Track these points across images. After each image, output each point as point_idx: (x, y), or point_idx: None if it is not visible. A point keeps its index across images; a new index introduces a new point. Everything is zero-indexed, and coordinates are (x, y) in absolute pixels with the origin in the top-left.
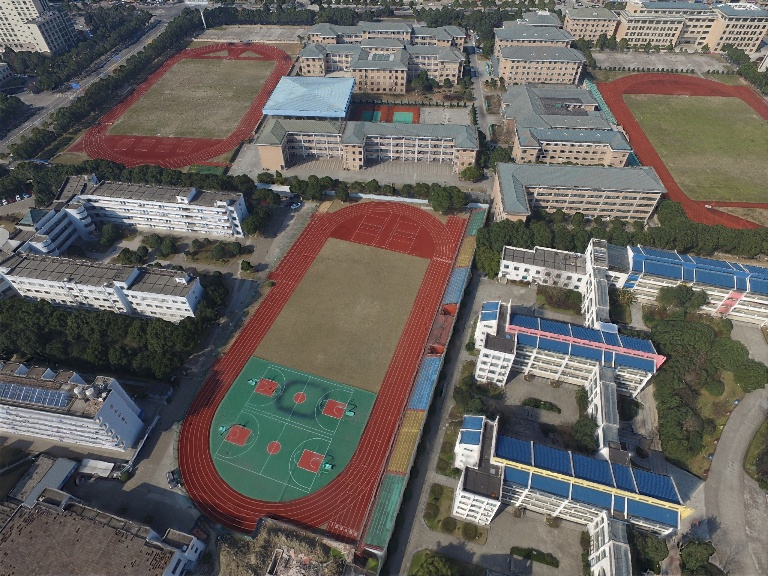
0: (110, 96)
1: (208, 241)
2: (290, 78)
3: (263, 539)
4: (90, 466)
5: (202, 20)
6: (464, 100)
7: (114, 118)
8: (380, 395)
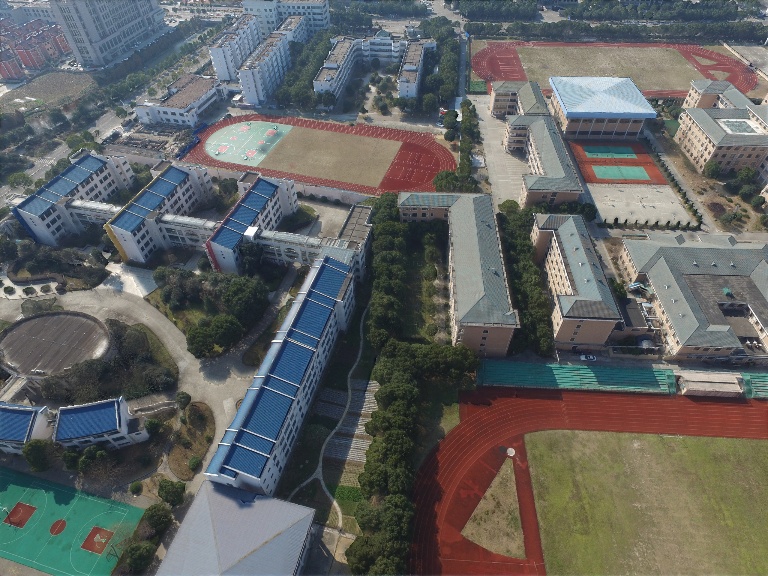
0: (574, 37)
1: (390, 97)
2: (626, 81)
3: (187, 137)
4: (239, 95)
5: None
6: (720, 220)
7: (541, 45)
8: (255, 167)
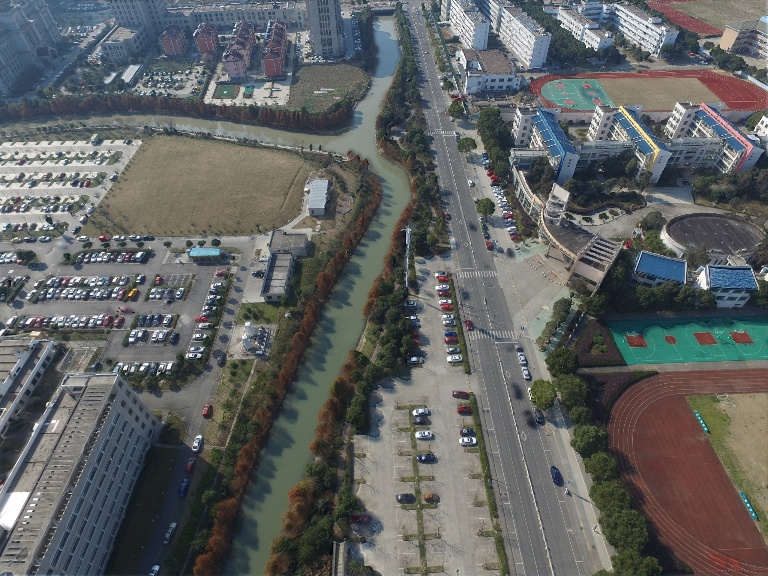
0: None
1: None
2: None
3: None
4: (518, 62)
5: None
6: None
7: (681, 1)
8: None
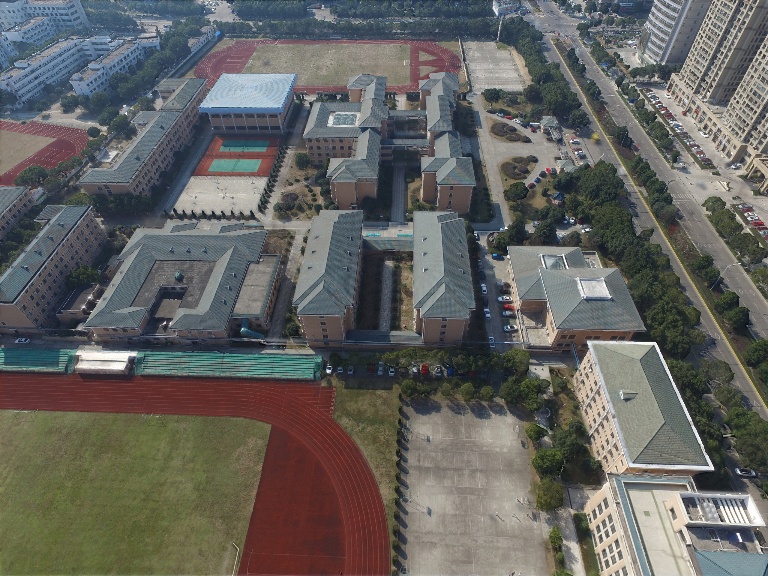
0: (324, 34)
1: None
2: (288, 77)
3: None
4: None
5: (499, 31)
6: None
7: (285, 43)
8: None
